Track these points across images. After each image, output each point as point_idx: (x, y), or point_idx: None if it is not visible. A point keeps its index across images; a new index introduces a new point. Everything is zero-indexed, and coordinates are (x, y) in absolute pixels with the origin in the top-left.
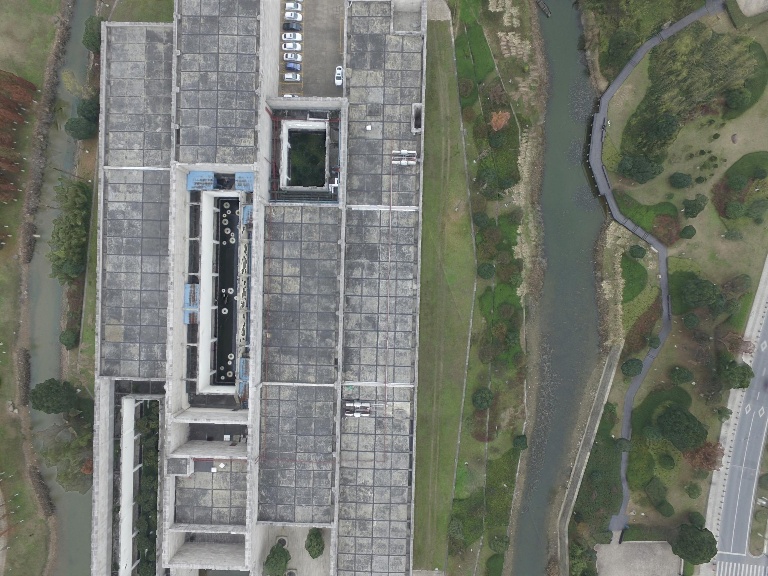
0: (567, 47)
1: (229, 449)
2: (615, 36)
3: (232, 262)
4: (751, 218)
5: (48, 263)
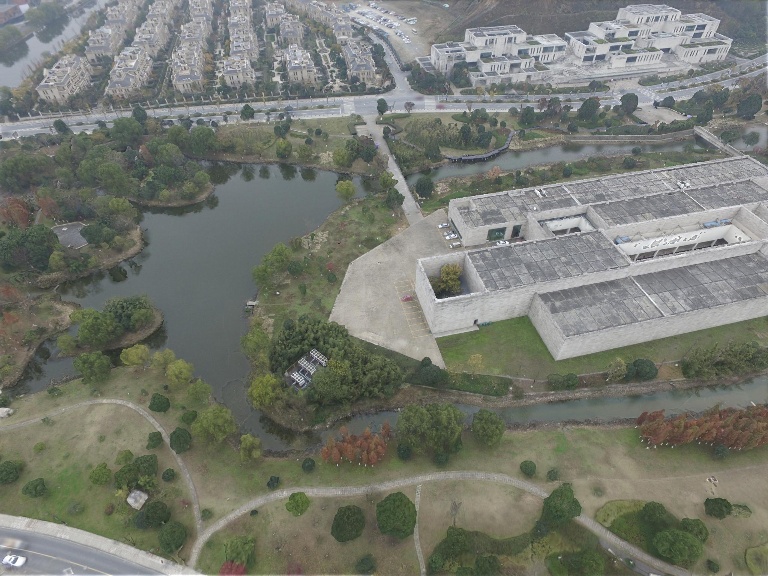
0: None
1: (766, 221)
2: None
3: None
4: None
5: (766, 391)
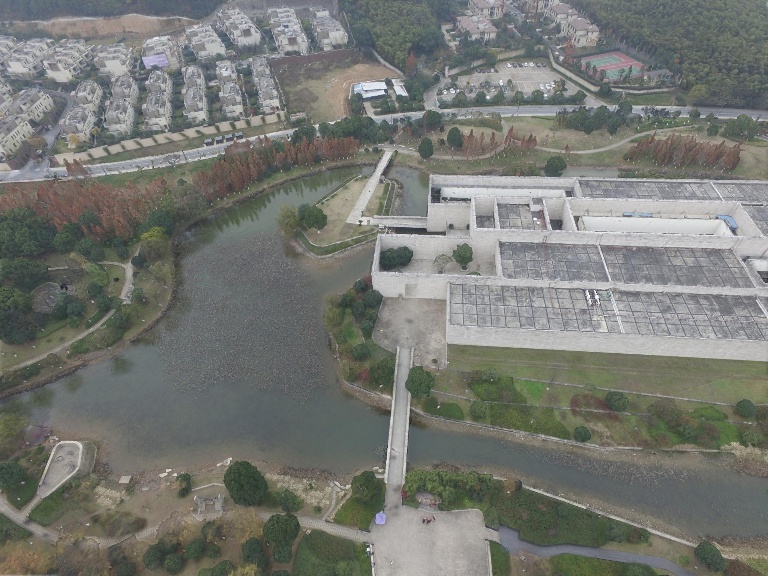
0: None
1: None
2: None
3: None
4: None
5: None
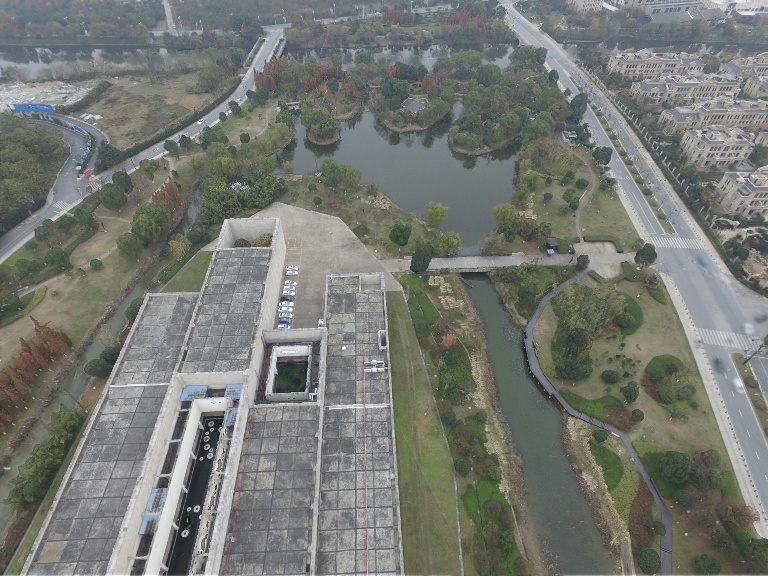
0: (490, 303)
1: None
2: (519, 288)
3: (202, 492)
4: (686, 403)
5: (4, 497)
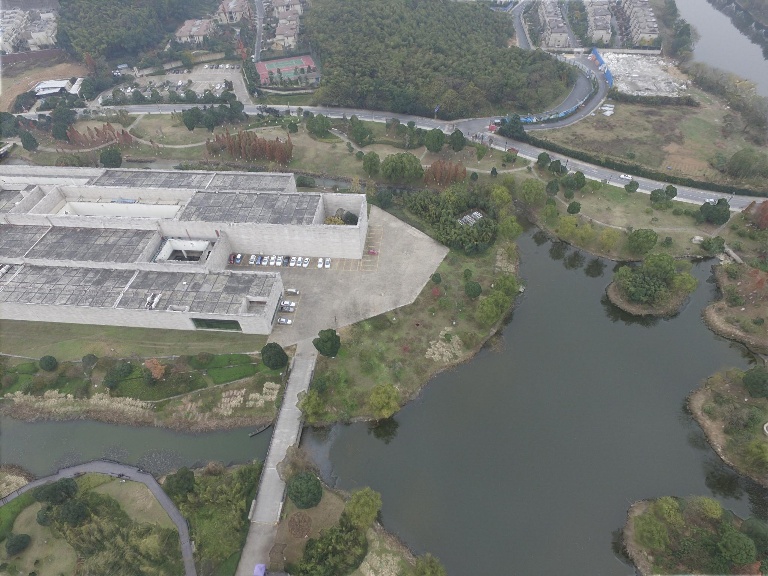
0: (218, 453)
1: (26, 212)
2: None
3: None
4: None
5: None
